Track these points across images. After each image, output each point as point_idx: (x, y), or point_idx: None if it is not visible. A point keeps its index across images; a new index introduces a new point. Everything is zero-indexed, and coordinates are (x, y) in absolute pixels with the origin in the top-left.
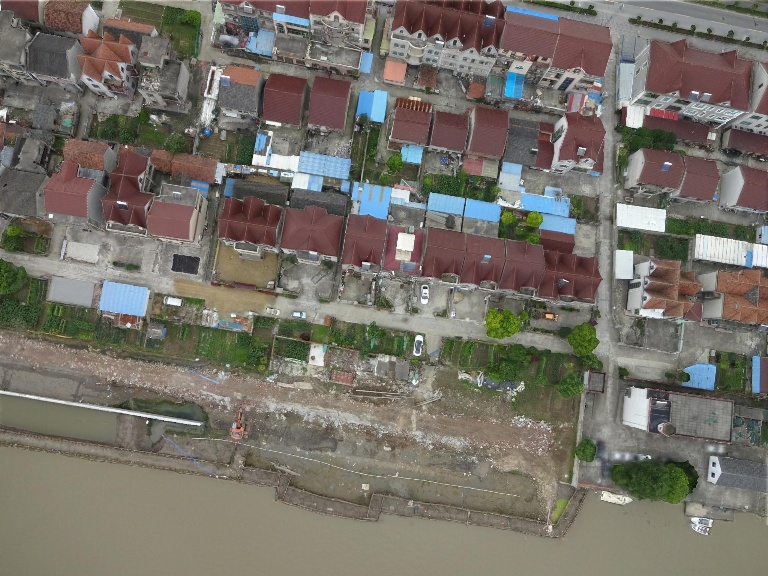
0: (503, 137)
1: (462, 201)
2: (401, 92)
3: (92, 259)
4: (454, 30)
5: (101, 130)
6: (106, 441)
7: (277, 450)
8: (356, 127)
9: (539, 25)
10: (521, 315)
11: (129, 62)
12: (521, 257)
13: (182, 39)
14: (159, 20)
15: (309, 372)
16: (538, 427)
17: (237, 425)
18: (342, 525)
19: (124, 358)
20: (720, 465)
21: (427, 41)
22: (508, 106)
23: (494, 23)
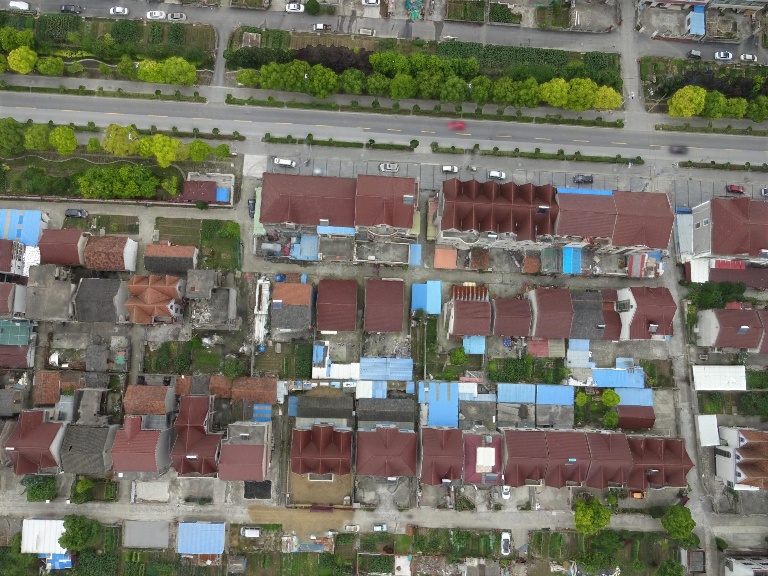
0: (568, 320)
1: (532, 388)
2: (453, 275)
3: (163, 497)
4: (506, 223)
5: (155, 361)
6: None
7: None
8: (413, 323)
9: (594, 206)
10: (608, 499)
11: (177, 298)
12: (606, 454)
13: (223, 252)
14: (197, 235)
15: None
16: None
17: None
18: None
19: None
20: None
21: (479, 237)
22: (565, 274)
23: (547, 211)
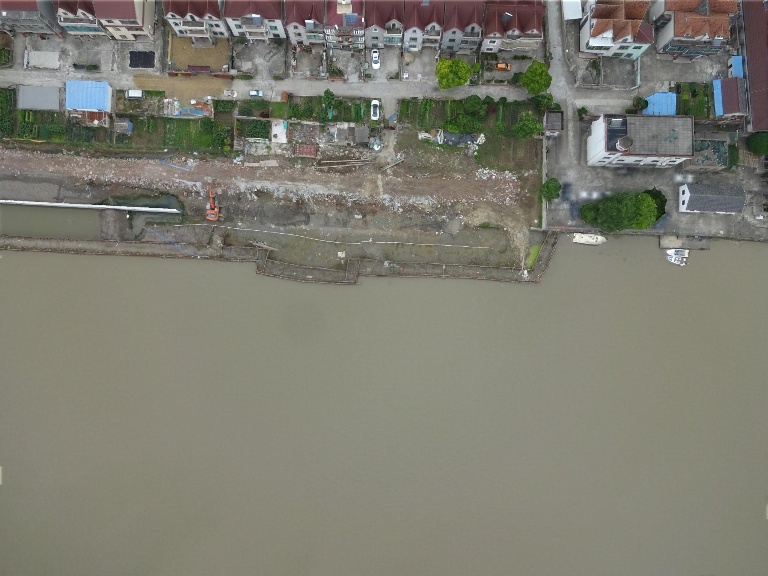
0: None
1: None
2: None
3: (54, 65)
4: None
5: None
6: (92, 238)
7: (253, 229)
8: None
9: None
10: (473, 67)
11: None
12: None
13: None
14: None
15: (273, 150)
16: (503, 177)
17: (211, 205)
18: (323, 291)
19: (97, 157)
20: (688, 189)
21: None
22: None
23: None
